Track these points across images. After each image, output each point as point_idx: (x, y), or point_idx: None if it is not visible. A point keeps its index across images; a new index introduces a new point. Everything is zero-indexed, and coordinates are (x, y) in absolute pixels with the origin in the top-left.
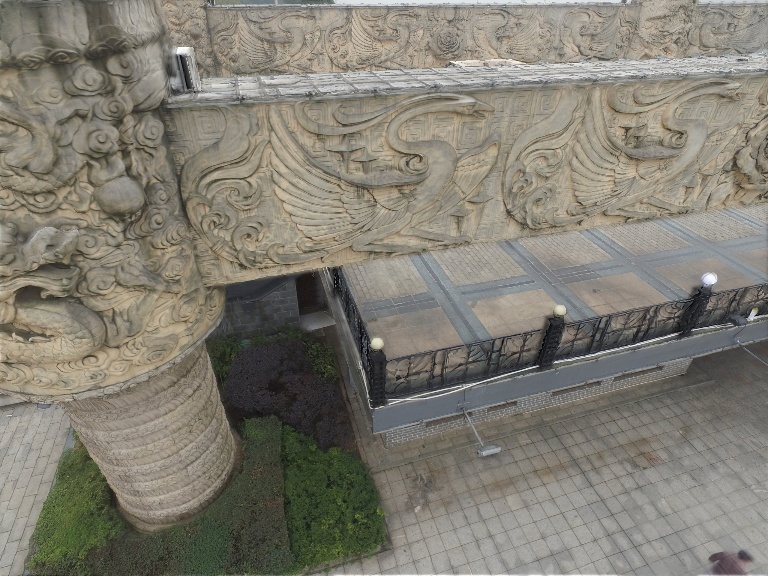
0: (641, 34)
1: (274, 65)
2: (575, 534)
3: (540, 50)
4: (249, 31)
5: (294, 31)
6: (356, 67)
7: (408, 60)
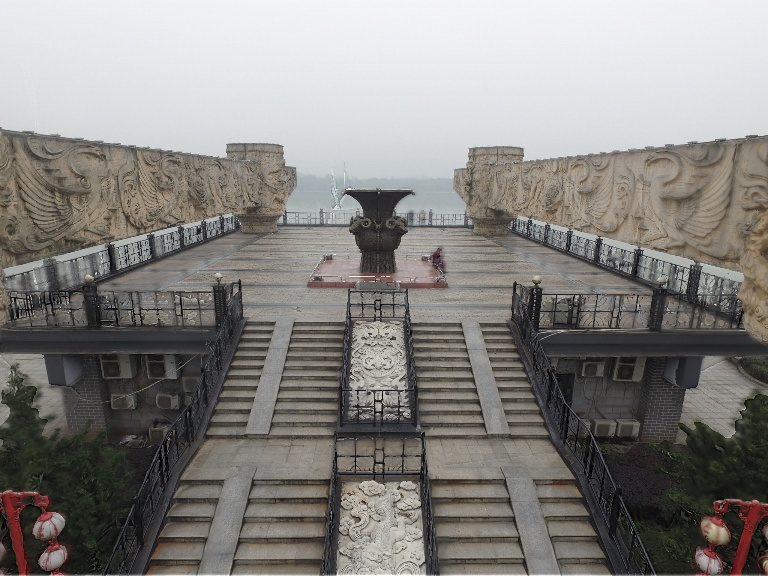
0: (268, 184)
1: (71, 231)
2: (698, 393)
3: (236, 198)
4: (33, 174)
5: (90, 176)
6: (148, 225)
7: (179, 212)
